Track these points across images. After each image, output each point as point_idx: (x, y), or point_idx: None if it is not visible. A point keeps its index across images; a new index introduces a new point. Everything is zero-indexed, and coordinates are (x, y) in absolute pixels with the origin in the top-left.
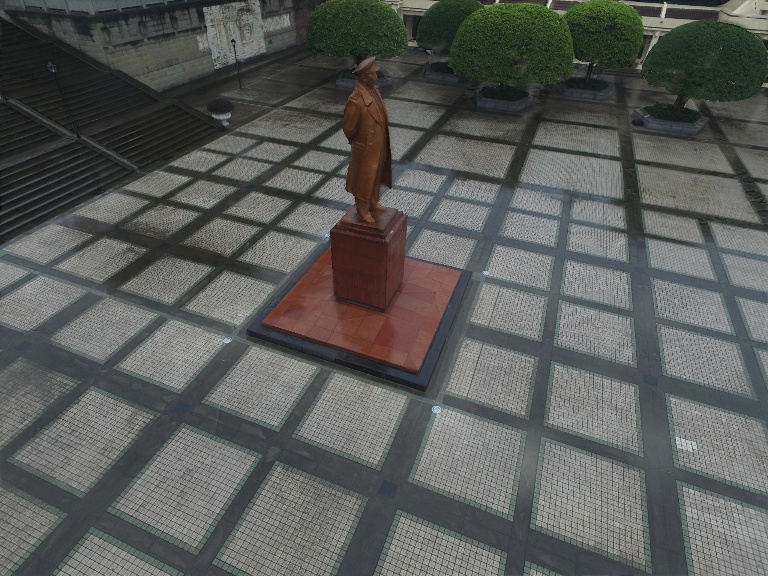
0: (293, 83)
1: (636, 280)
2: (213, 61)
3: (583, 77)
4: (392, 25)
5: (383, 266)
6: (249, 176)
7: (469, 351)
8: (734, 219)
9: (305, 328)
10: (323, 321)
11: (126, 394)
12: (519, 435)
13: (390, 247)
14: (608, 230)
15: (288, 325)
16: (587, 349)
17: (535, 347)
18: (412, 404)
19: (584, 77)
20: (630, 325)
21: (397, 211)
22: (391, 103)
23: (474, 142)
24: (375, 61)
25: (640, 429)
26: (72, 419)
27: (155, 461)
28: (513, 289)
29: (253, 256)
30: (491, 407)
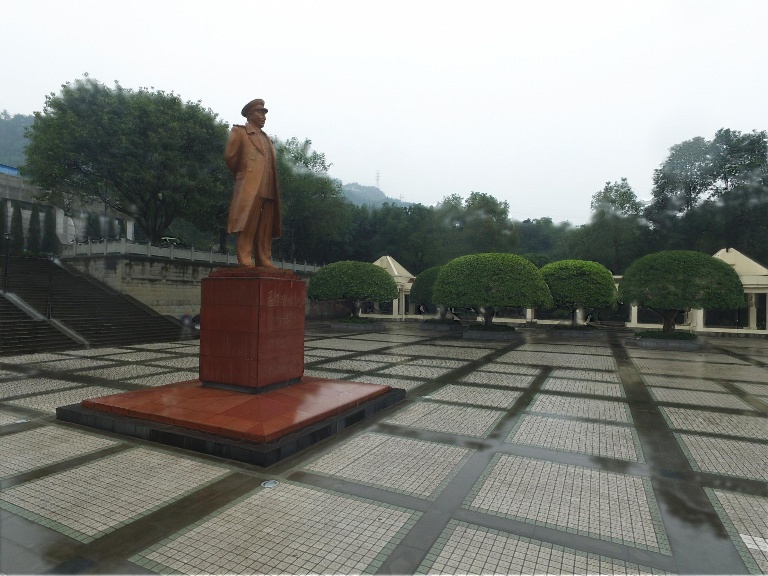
0: None
1: (637, 406)
2: None
3: (570, 323)
4: (382, 277)
5: (255, 314)
6: None
7: (366, 440)
8: (763, 382)
9: (135, 404)
10: (166, 399)
11: None
12: (406, 515)
13: (267, 291)
14: (597, 382)
15: (115, 402)
16: (559, 446)
17: (474, 441)
18: (232, 477)
19: (571, 323)
20: (630, 432)
21: (291, 272)
22: (378, 334)
23: (452, 347)
24: None
25: (659, 521)
26: None
27: None
28: (458, 405)
29: (142, 380)
30: (370, 485)
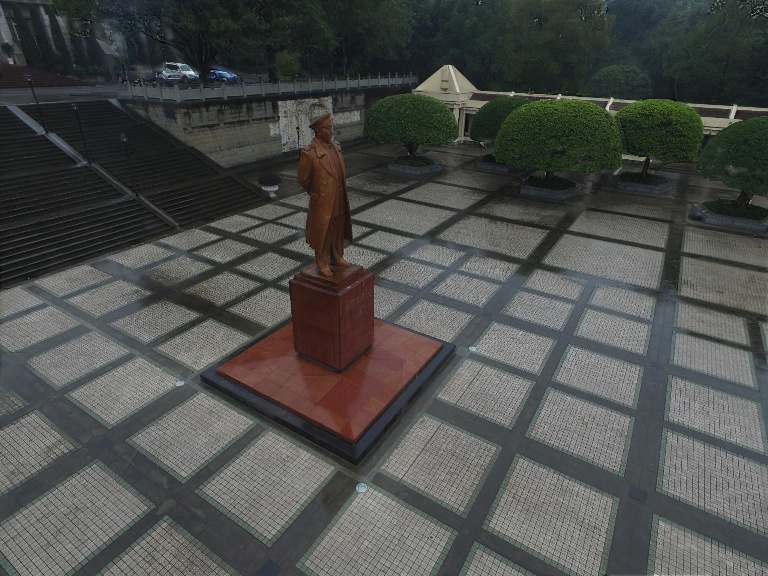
0: (349, 166)
1: (649, 375)
2: (282, 145)
3: (640, 172)
4: (442, 118)
5: (336, 322)
6: (273, 239)
7: (423, 428)
8: None
9: (255, 380)
10: (275, 375)
11: (61, 422)
12: (447, 534)
13: (344, 302)
14: (629, 319)
15: (240, 375)
16: (565, 445)
17: (502, 434)
18: (337, 477)
19: (640, 172)
20: (628, 425)
21: None
22: (434, 186)
23: (506, 224)
24: (433, 152)
25: (607, 554)
26: (1, 438)
27: (51, 493)
28: (497, 368)
29: (242, 308)
30: (425, 495)
